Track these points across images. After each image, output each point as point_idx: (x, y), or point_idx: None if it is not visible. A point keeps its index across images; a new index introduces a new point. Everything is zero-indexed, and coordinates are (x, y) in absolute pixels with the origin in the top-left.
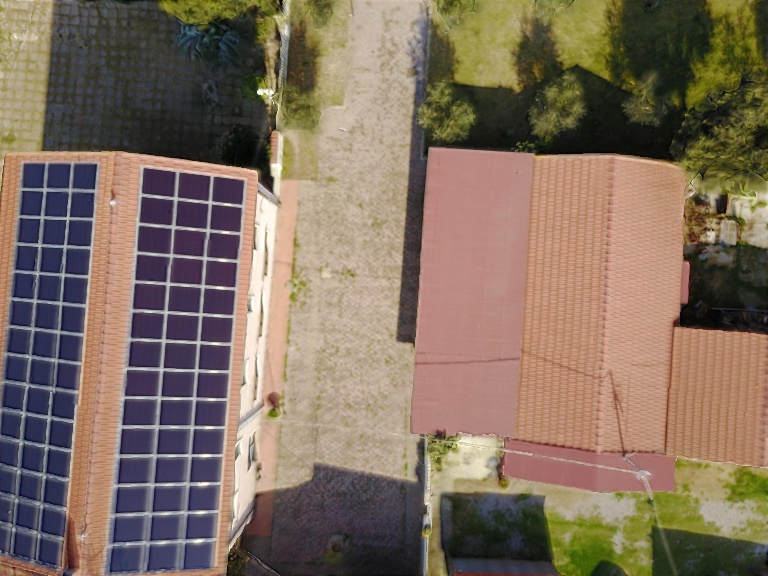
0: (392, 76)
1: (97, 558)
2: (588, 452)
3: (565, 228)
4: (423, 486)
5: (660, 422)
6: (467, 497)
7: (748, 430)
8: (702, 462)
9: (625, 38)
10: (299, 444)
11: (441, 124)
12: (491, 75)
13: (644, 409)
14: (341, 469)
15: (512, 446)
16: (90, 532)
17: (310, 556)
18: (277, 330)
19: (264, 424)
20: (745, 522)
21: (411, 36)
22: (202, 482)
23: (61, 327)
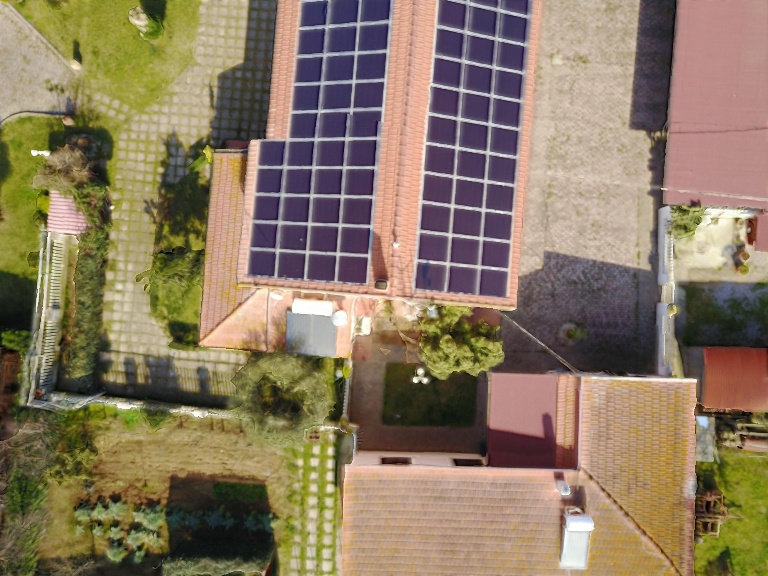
0: None
1: (404, 272)
2: None
3: None
4: (656, 275)
5: None
6: (701, 287)
7: None
8: None
9: None
10: (529, 233)
11: None
12: None
13: None
14: (572, 258)
15: (766, 219)
16: (399, 244)
17: None
18: None
19: None
20: None
21: None
22: (496, 210)
23: (358, 48)
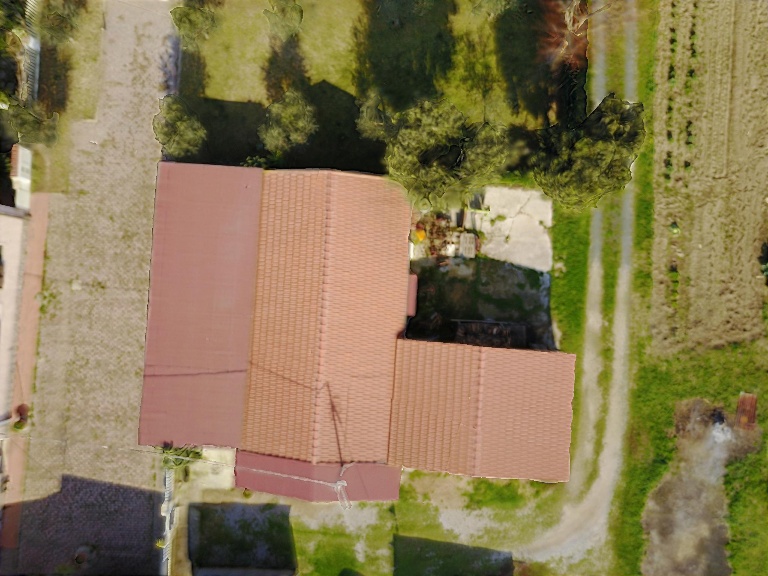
0: (144, 90)
1: None
2: (305, 463)
3: (290, 242)
4: None
5: (383, 432)
6: (215, 507)
7: (462, 440)
8: (442, 471)
9: (371, 54)
10: (48, 456)
11: (170, 139)
12: (241, 89)
13: (365, 420)
14: (89, 480)
15: (242, 457)
16: None
17: (57, 567)
18: (26, 342)
19: (12, 436)
20: (482, 529)
21: (163, 50)
22: None
23: None
